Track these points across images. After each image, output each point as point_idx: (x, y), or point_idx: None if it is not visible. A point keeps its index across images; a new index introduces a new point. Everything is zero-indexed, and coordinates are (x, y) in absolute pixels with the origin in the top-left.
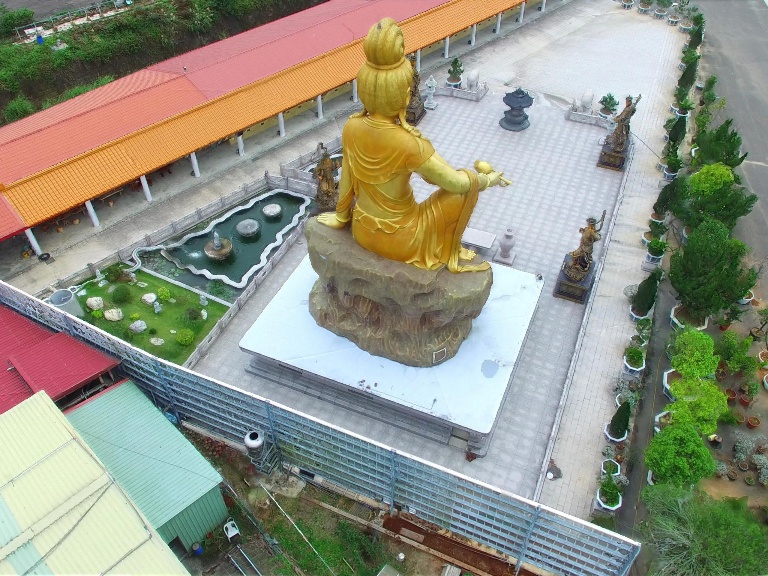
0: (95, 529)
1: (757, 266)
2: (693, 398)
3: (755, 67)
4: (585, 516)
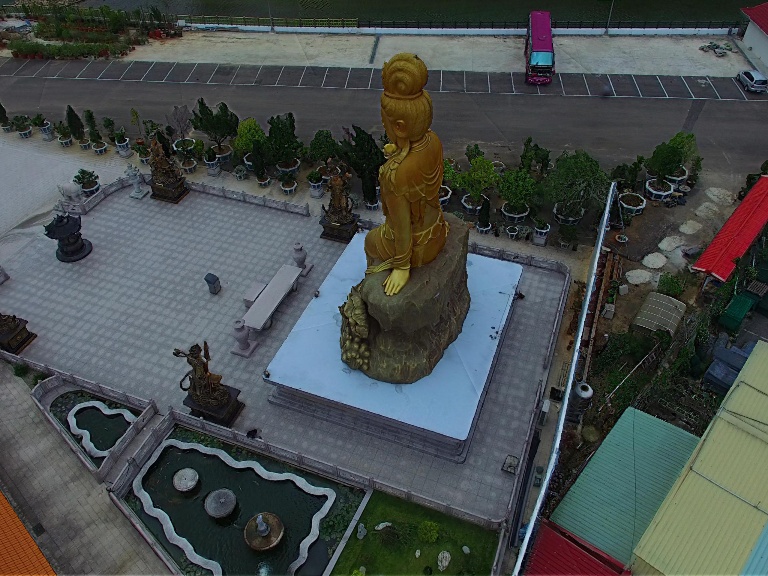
0: (762, 414)
1: (346, 137)
2: (471, 177)
3: (49, 102)
4: (546, 249)
